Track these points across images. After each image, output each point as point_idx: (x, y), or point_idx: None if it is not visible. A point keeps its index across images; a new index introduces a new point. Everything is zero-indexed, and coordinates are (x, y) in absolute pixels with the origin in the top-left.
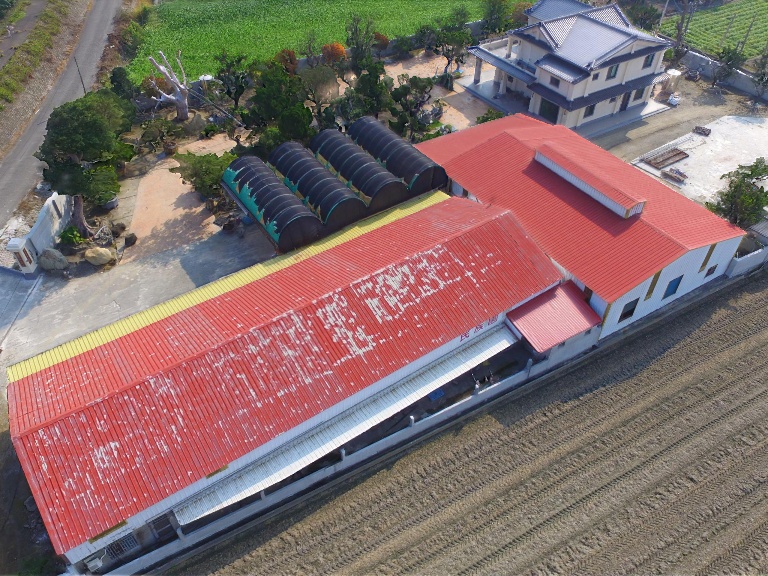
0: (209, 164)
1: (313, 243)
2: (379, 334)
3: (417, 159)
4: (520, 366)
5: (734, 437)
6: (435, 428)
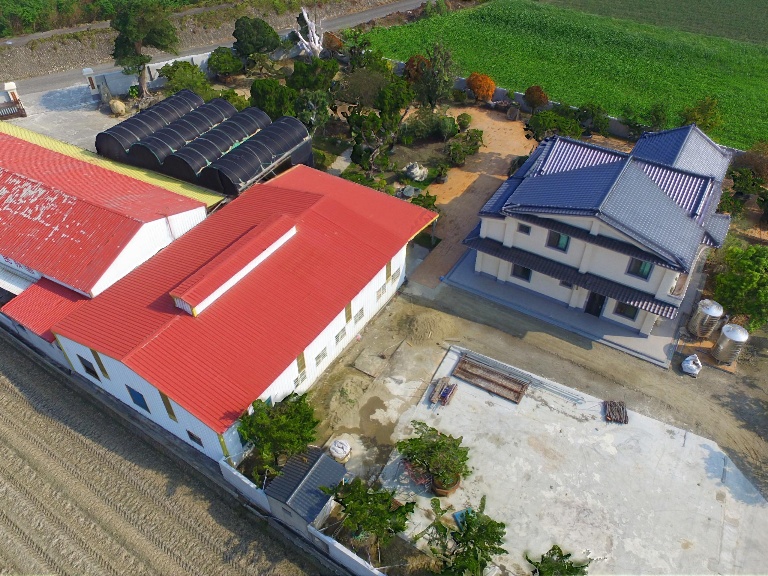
0: (192, 87)
1: (117, 161)
2: None
3: (225, 158)
4: None
5: None
6: None
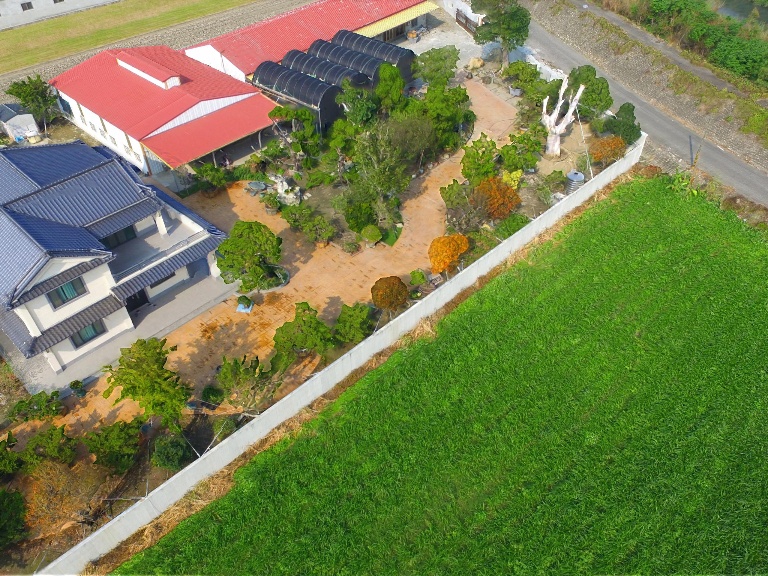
0: None
1: None
2: None
3: (275, 64)
4: None
5: None
6: None
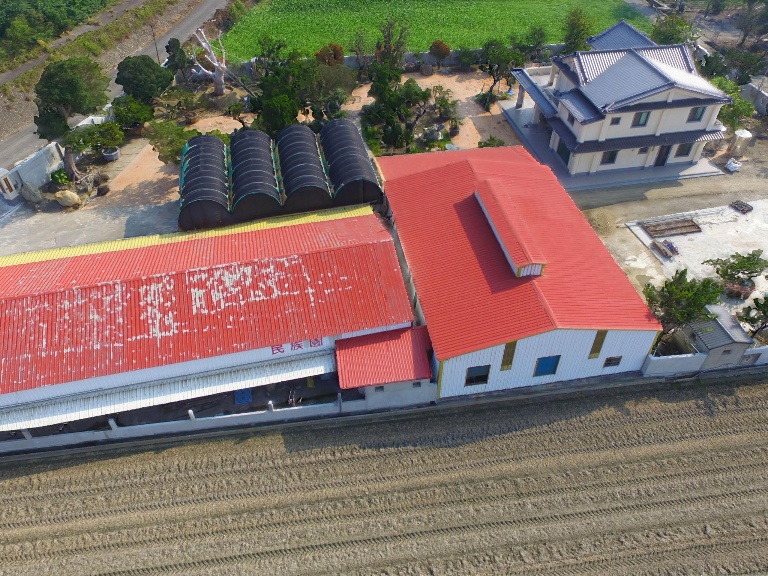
0: (180, 137)
1: (216, 227)
2: (186, 323)
3: (352, 169)
4: (342, 398)
5: (513, 547)
6: (222, 430)
